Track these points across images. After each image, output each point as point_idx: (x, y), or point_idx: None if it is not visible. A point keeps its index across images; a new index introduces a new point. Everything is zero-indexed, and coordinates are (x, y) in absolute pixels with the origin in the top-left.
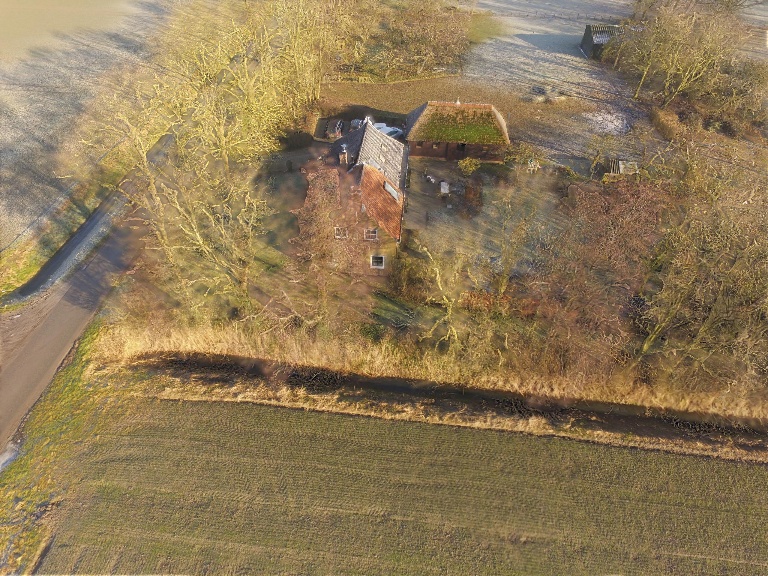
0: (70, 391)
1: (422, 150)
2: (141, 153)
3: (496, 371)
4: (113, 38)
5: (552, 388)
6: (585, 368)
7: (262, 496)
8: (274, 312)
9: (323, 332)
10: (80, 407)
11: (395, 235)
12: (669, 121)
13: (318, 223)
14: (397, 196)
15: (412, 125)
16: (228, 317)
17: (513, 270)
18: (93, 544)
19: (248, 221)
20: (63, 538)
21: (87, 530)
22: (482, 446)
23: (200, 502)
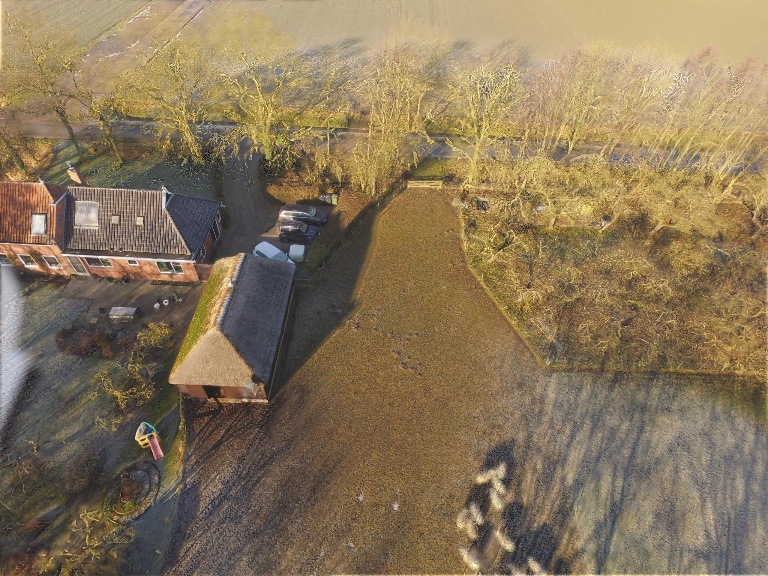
0: (1, 144)
1: None
2: None
3: None
4: (518, 65)
5: None
6: None
7: None
8: None
9: None
10: None
11: None
12: None
13: None
14: (40, 234)
15: None
16: None
17: None
18: None
19: None
20: None
21: None
22: None
23: None
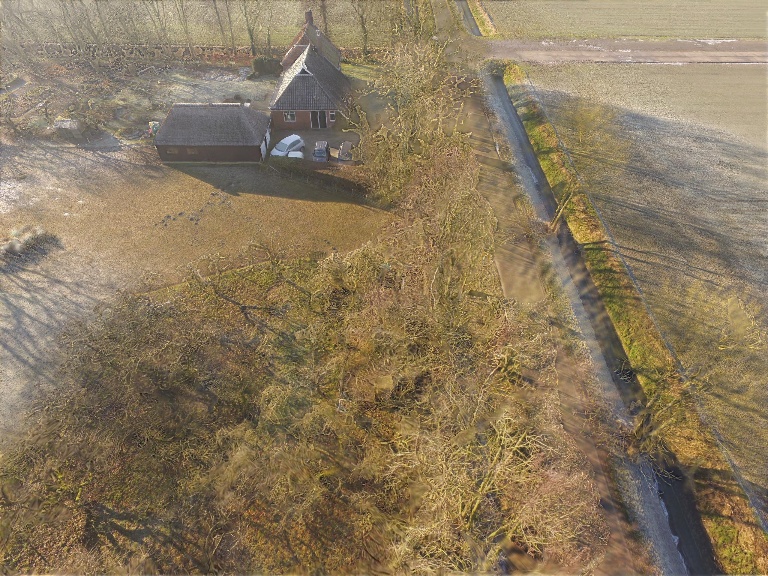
0: None
1: None
2: None
3: None
4: None
5: None
6: None
7: None
8: None
9: None
10: None
11: None
12: None
13: None
14: None
15: None
16: None
17: None
18: None
19: None
20: None
21: None
22: None
23: None
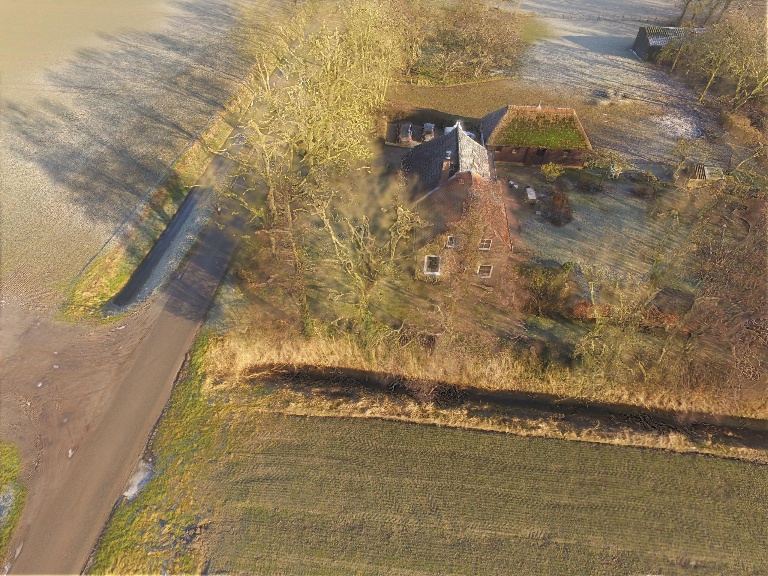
0: (192, 407)
1: (500, 155)
2: (266, 161)
3: (621, 384)
4: (159, 39)
5: (680, 402)
6: (712, 381)
7: (415, 518)
8: (384, 323)
9: (443, 345)
10: (206, 423)
11: (508, 244)
12: (743, 125)
13: (475, 236)
14: None
15: (492, 130)
16: (338, 328)
17: (678, 285)
18: (252, 570)
19: (399, 233)
20: (219, 563)
21: (243, 555)
22: (627, 464)
23: (352, 524)
